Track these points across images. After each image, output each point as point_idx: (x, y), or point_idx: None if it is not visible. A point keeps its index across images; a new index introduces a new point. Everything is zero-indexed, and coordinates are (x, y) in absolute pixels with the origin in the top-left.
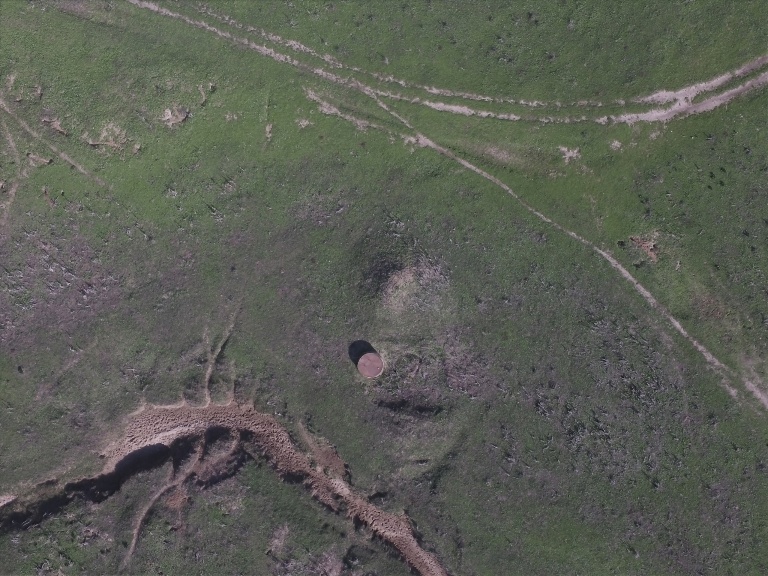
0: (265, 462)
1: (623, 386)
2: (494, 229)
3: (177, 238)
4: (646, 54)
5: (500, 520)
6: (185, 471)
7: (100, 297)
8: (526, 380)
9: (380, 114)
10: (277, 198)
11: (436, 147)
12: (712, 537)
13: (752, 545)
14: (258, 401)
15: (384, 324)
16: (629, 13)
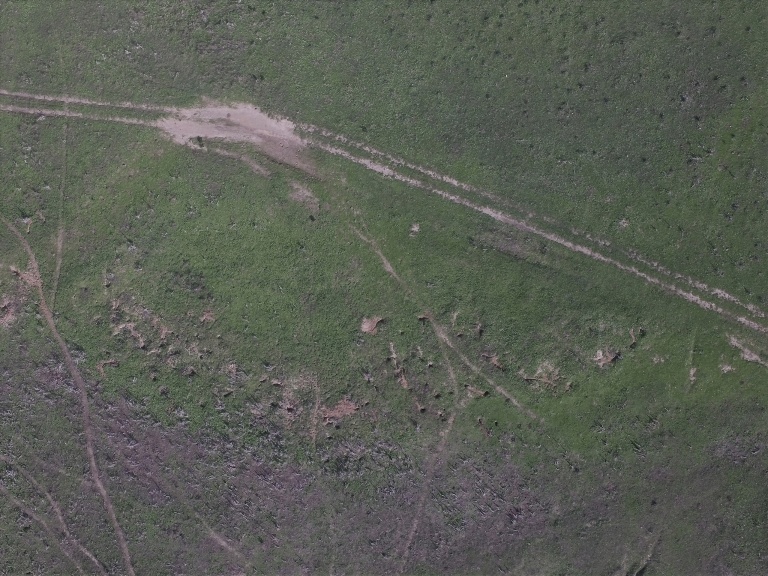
0: None
1: None
2: None
3: (601, 470)
4: None
5: None
6: None
7: (527, 522)
8: None
9: None
10: (697, 438)
11: None
12: None
13: None
14: None
15: None
16: None
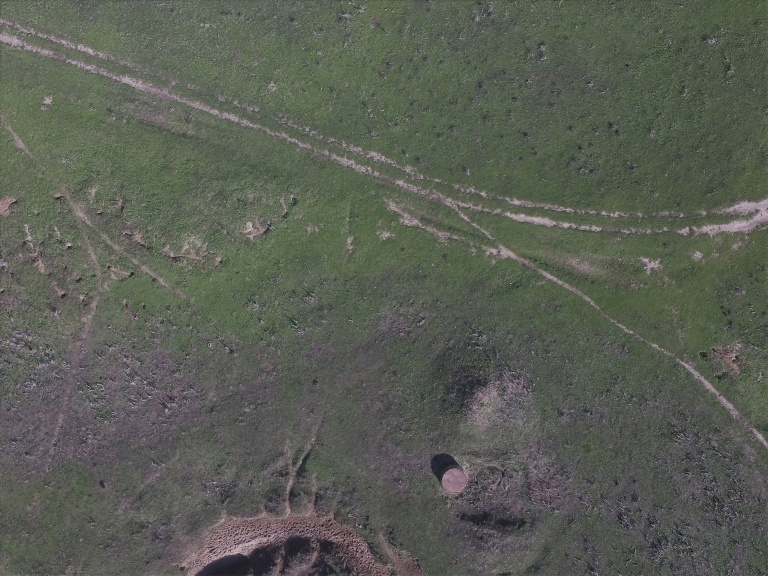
0: (347, 575)
1: (706, 499)
2: (576, 341)
3: (258, 351)
4: (727, 164)
5: None
6: None
7: (181, 410)
8: (609, 493)
9: (461, 226)
10: (358, 310)
11: (517, 258)
12: None
13: None
14: (339, 513)
15: (468, 439)
16: (710, 123)
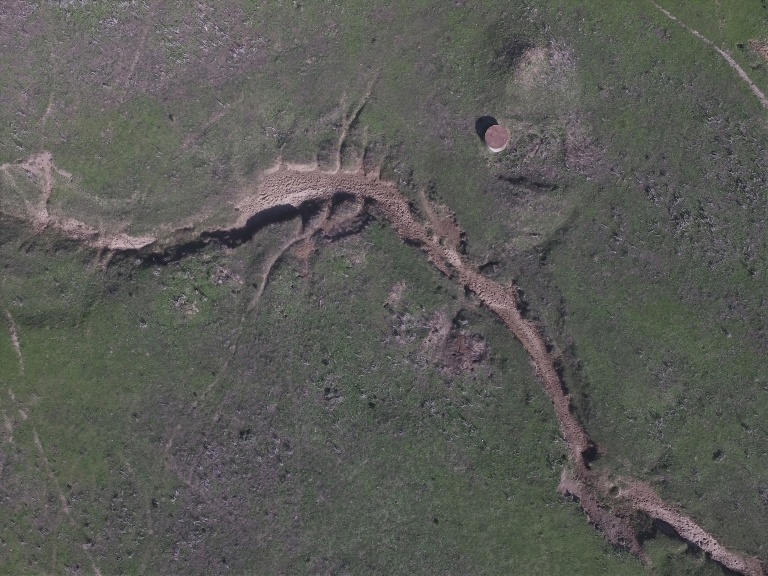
0: (388, 224)
1: (730, 180)
2: (621, 22)
3: (324, 8)
4: None
5: (603, 294)
6: (314, 226)
7: (248, 57)
8: (639, 167)
9: None
10: None
11: None
12: None
13: None
14: (385, 169)
15: (512, 100)
16: None
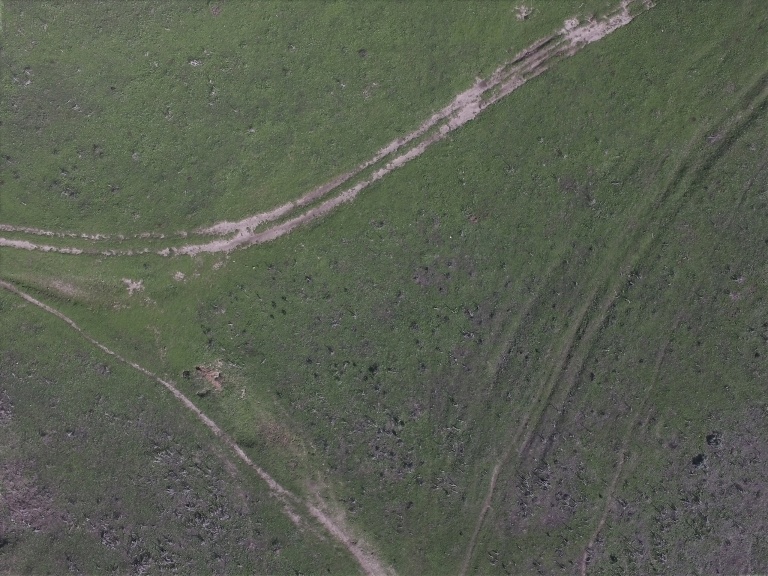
0: None
1: (188, 515)
2: (57, 362)
3: None
4: (208, 185)
5: None
6: None
7: None
8: (92, 511)
9: None
10: None
11: None
12: None
13: None
14: None
15: None
16: (192, 144)
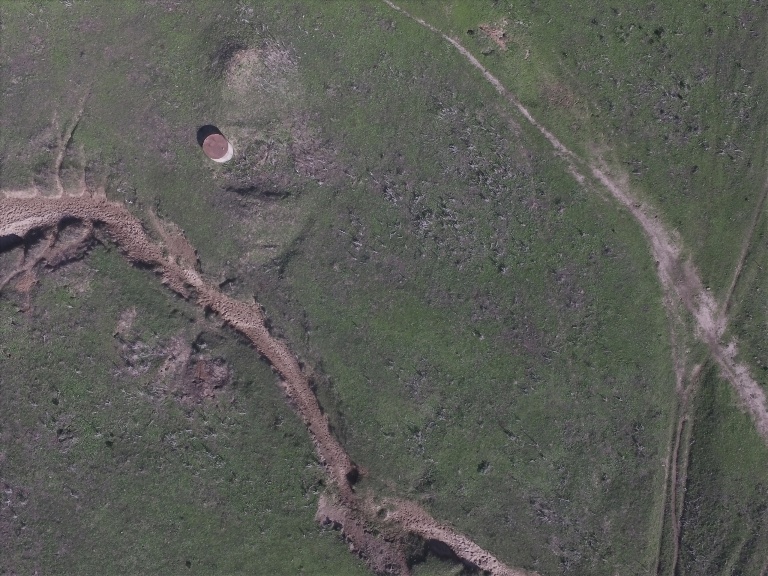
0: (114, 247)
1: (471, 173)
2: (343, 17)
3: (27, 24)
4: None
5: (347, 304)
6: (35, 256)
7: None
8: (374, 167)
9: None
10: None
11: None
12: (557, 321)
13: (597, 329)
14: (109, 189)
15: (230, 106)
16: None
